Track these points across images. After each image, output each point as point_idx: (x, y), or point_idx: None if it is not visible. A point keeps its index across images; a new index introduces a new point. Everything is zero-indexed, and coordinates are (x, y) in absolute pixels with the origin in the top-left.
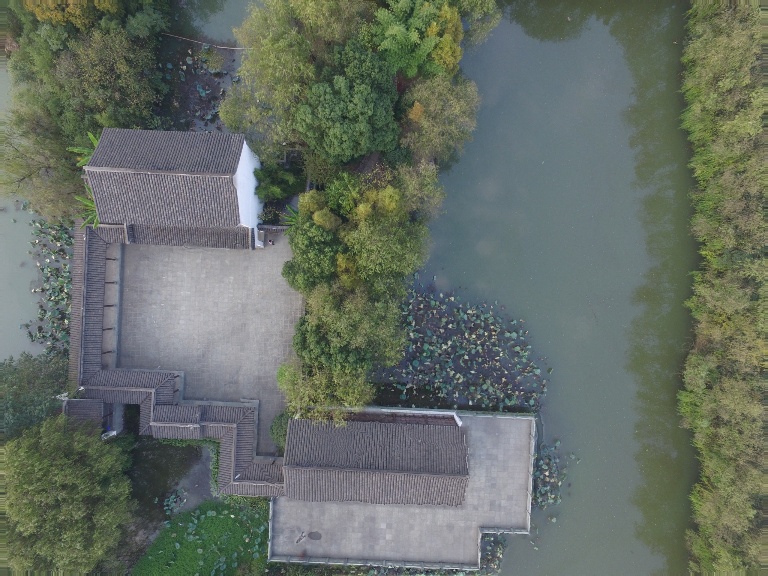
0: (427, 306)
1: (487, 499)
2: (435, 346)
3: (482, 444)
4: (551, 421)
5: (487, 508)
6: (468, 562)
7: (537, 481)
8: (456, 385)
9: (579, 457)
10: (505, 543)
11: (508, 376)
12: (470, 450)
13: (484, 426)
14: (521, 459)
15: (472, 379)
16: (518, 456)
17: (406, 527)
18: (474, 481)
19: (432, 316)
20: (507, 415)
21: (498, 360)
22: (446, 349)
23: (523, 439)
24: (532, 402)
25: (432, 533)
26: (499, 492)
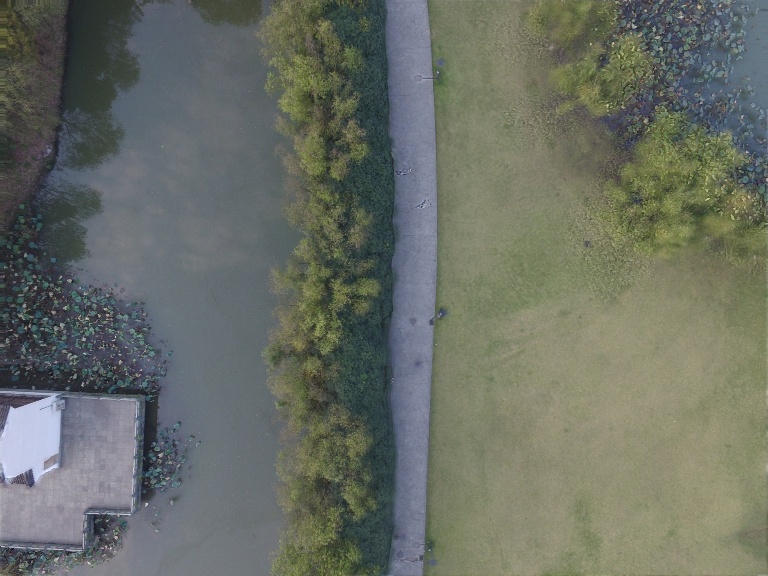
0: (39, 288)
1: (96, 481)
2: (47, 328)
3: (91, 426)
4: (170, 404)
5: (96, 489)
6: (78, 543)
7: (148, 463)
8: (71, 367)
9: (198, 440)
10: (124, 525)
11: (124, 358)
12: (79, 432)
13: (93, 408)
14: (130, 441)
15: (88, 361)
16: (127, 438)
17: (16, 508)
18: (84, 462)
19: (46, 298)
20: (112, 397)
21: (113, 342)
22: (60, 331)
23: (132, 421)
24: (145, 384)
25: (42, 514)
26: (108, 474)
